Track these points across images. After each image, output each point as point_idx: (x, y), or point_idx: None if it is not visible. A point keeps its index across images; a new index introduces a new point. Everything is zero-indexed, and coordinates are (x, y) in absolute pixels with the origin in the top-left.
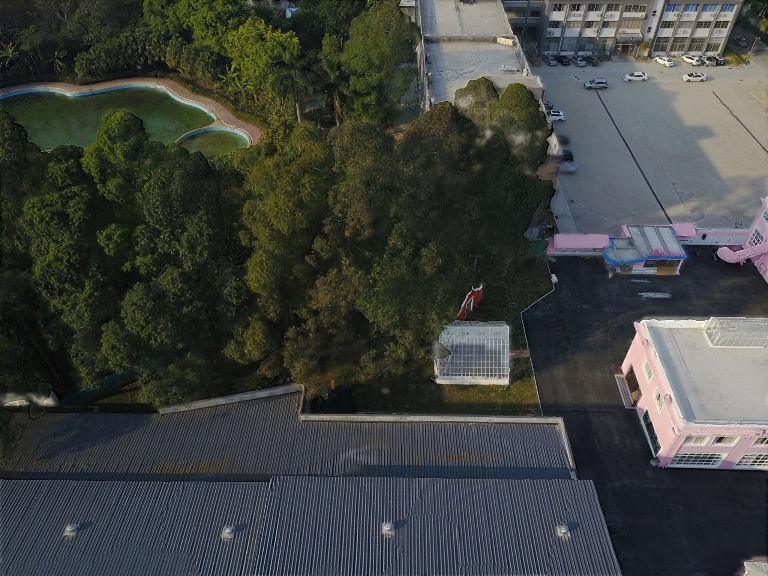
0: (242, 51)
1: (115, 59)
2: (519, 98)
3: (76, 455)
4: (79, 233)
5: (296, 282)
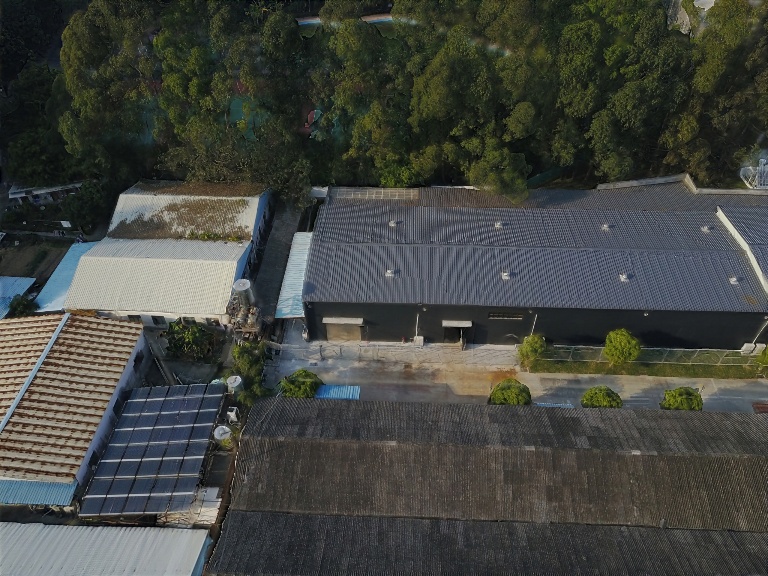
0: None
1: None
2: None
3: (559, 206)
4: (596, 48)
5: (707, 94)
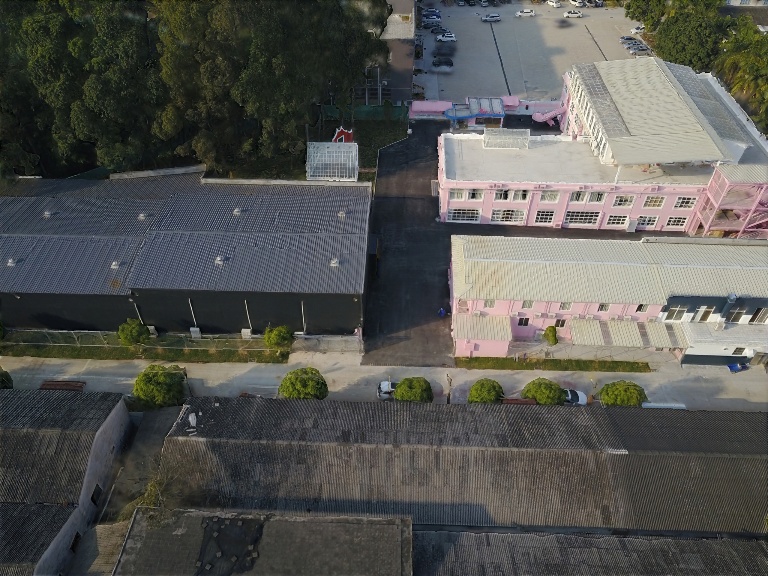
0: None
1: None
2: None
3: (54, 195)
4: (56, 40)
5: (197, 86)
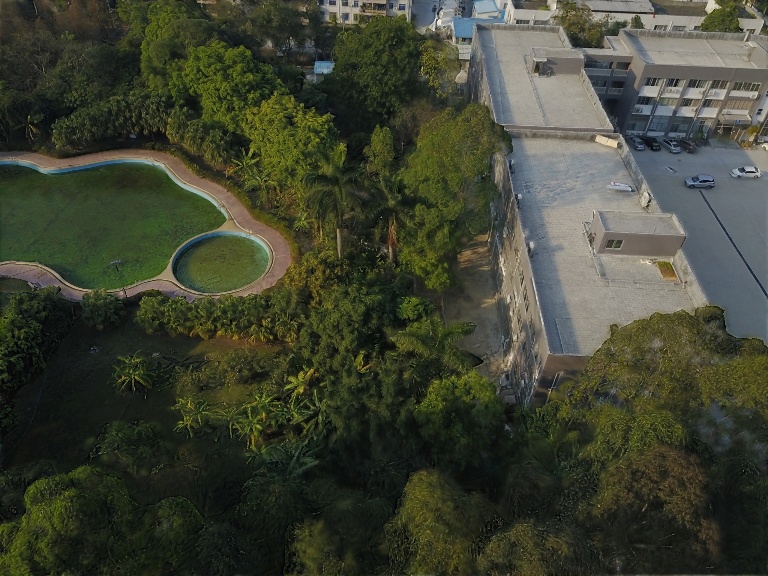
0: (264, 136)
1: (103, 128)
2: None
3: None
4: None
5: None
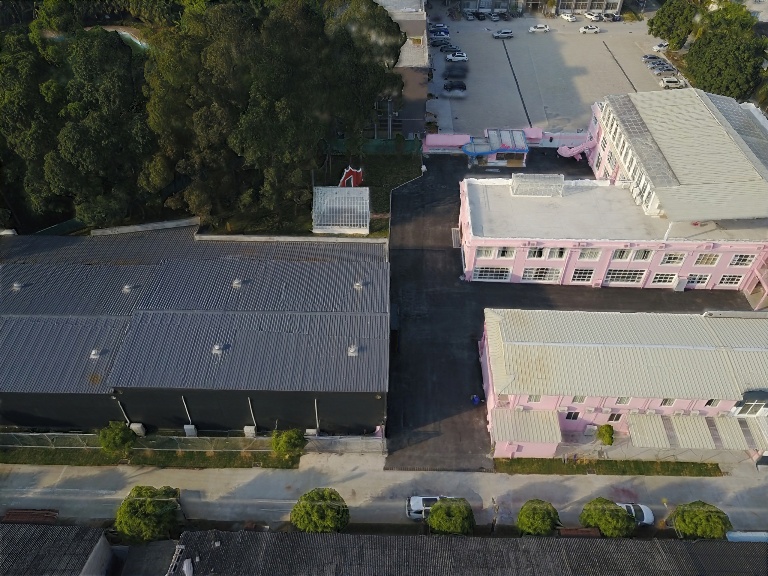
0: None
1: (86, 8)
2: (360, 1)
3: (27, 257)
4: (26, 84)
5: (189, 132)
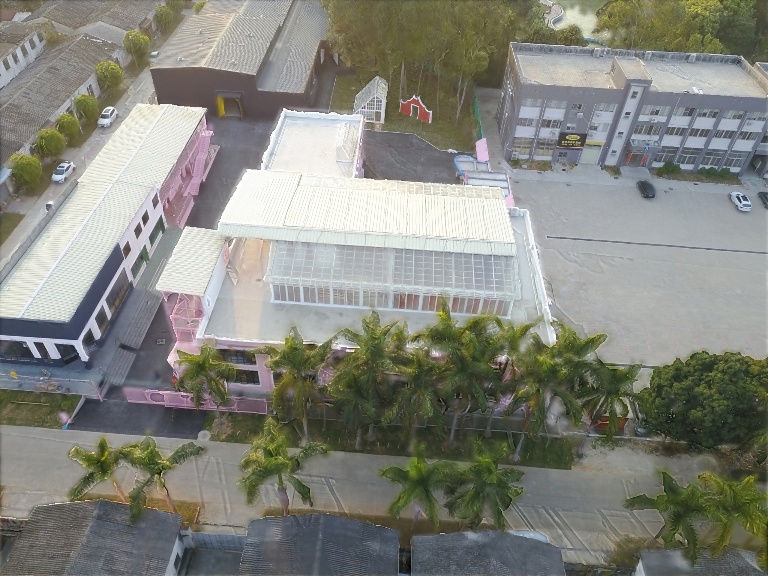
0: None
1: None
2: None
3: (311, 7)
4: None
5: None
